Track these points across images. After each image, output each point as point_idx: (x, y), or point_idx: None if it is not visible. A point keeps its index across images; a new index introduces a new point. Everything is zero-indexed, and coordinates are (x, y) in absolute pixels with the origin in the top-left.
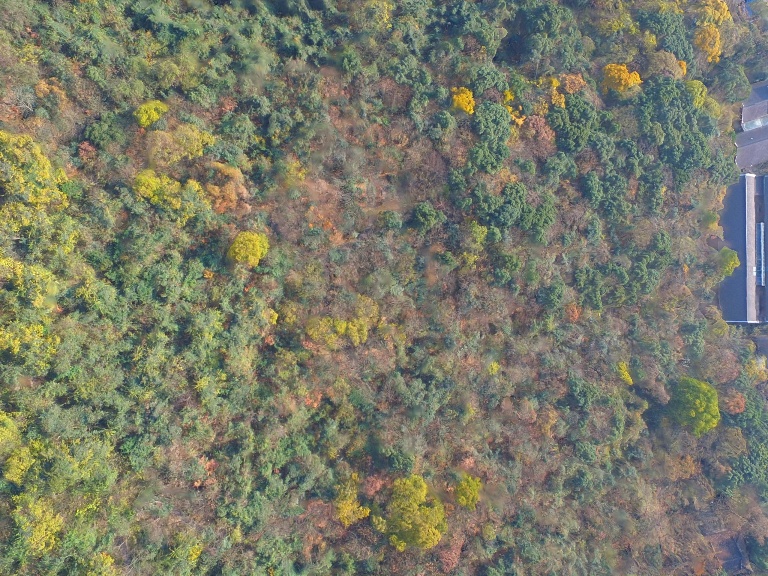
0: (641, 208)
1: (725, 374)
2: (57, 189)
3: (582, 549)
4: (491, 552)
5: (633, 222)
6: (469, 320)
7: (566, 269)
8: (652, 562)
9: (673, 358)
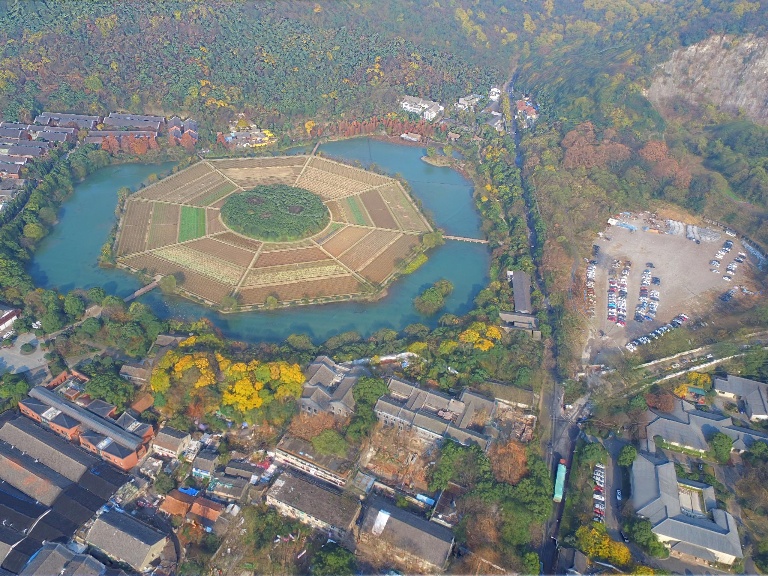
0: None
1: None
2: (199, 0)
3: None
4: None
5: None
6: None
7: None
8: None
9: None
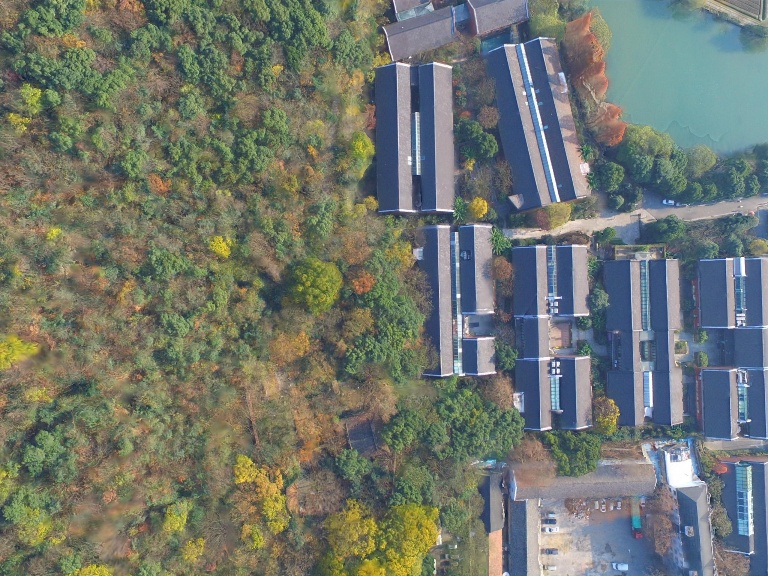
0: (251, 85)
1: (351, 254)
2: None
3: (180, 423)
4: (46, 416)
5: (241, 99)
6: (56, 194)
7: (160, 143)
8: (278, 442)
9: (294, 238)
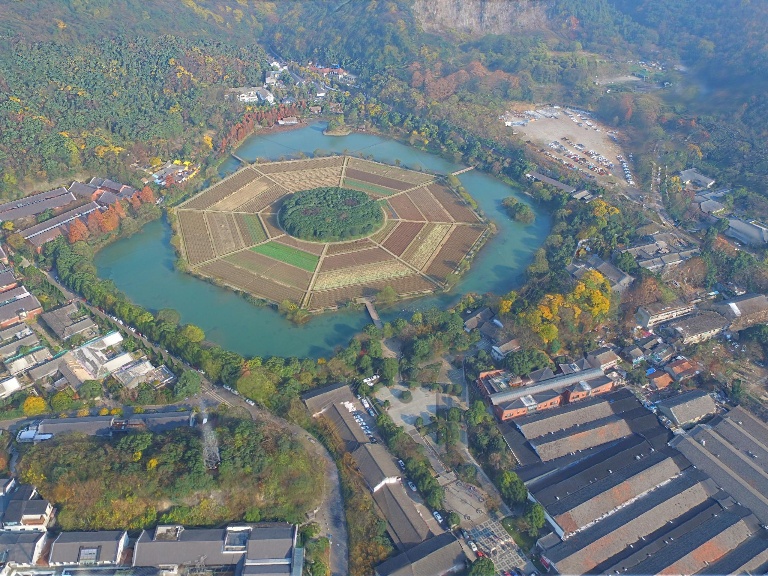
0: None
1: None
2: None
3: None
4: None
5: None
6: None
7: None
8: None
9: None
